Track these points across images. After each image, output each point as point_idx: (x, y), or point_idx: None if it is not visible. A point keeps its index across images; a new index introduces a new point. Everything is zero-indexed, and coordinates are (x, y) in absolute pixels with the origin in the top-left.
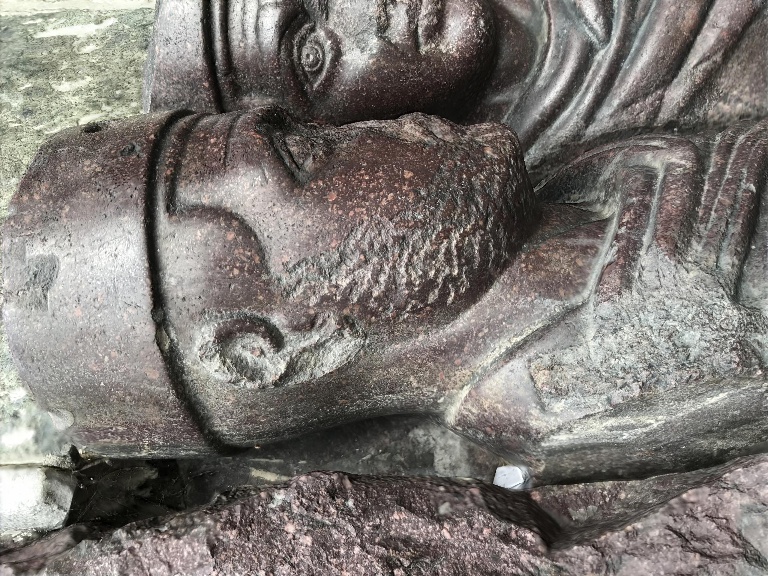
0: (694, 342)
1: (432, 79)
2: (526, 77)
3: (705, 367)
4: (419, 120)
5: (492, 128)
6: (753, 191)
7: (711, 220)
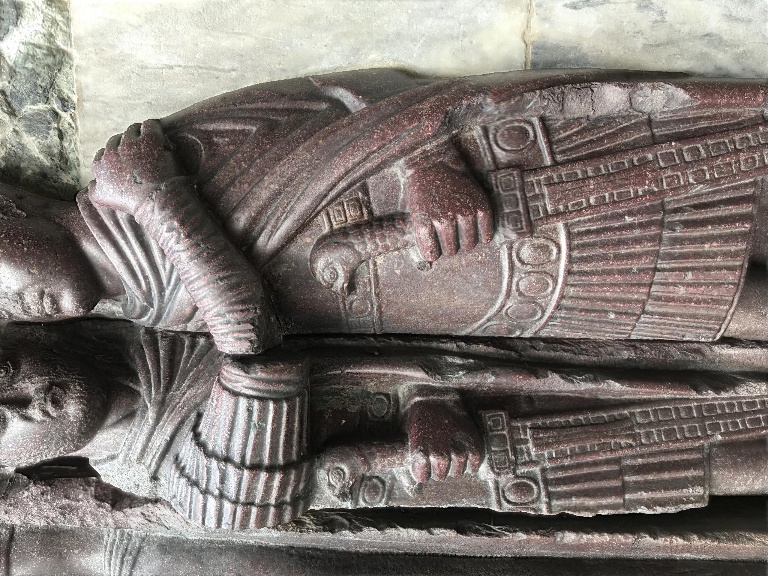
0: (141, 485)
1: (66, 318)
2: (125, 294)
3: (141, 494)
4: (41, 406)
5: (74, 405)
6: (168, 440)
7: (152, 448)
